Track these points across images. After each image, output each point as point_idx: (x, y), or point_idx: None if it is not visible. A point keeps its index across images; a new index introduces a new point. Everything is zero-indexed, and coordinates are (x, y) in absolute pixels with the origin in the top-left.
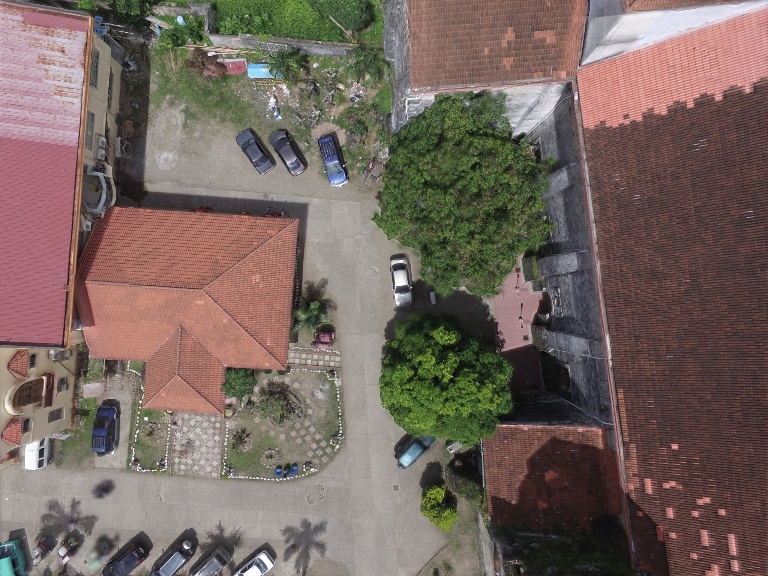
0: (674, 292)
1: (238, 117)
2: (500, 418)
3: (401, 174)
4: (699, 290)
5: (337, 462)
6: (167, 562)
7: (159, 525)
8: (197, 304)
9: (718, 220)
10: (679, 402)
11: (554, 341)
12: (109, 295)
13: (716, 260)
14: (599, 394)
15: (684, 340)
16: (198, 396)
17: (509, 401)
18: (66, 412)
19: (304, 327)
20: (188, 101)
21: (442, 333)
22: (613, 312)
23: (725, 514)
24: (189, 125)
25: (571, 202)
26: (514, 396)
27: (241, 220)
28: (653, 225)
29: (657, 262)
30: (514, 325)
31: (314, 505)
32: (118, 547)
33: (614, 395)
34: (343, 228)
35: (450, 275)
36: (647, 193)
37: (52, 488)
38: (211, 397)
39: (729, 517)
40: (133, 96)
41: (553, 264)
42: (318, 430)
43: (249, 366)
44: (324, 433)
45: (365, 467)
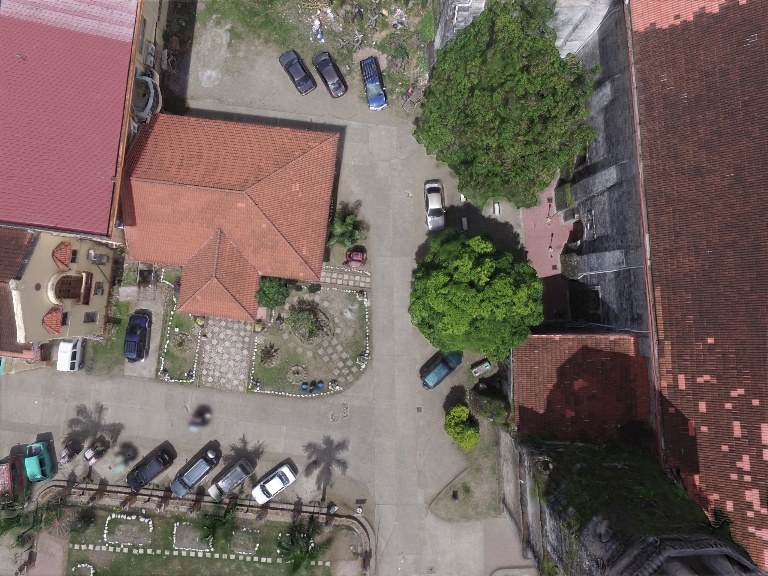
0: (717, 187)
1: (282, 39)
2: (531, 331)
3: (447, 81)
4: (743, 183)
5: (362, 382)
6: (192, 468)
7: (184, 435)
8: (238, 206)
9: (765, 113)
10: (717, 296)
11: (585, 264)
12: (153, 193)
13: (762, 152)
14: (632, 304)
15: (725, 234)
16: (233, 300)
17: (541, 314)
18: (100, 317)
19: (336, 247)
20: (234, 21)
21: (479, 241)
22: (654, 211)
23: (759, 404)
24: (233, 44)
25: (612, 117)
26: (541, 323)
27: (283, 132)
28: (699, 122)
29: (701, 158)
30: (544, 254)
31: (338, 423)
32: (143, 455)
33: (651, 294)
34: (379, 152)
35: (491, 181)
36: (694, 91)
37: (81, 393)
38: (245, 303)
39: (763, 407)
40: (180, 14)
41: (589, 185)
42: (345, 349)
43: (284, 275)
44: (351, 352)
45: (390, 388)
